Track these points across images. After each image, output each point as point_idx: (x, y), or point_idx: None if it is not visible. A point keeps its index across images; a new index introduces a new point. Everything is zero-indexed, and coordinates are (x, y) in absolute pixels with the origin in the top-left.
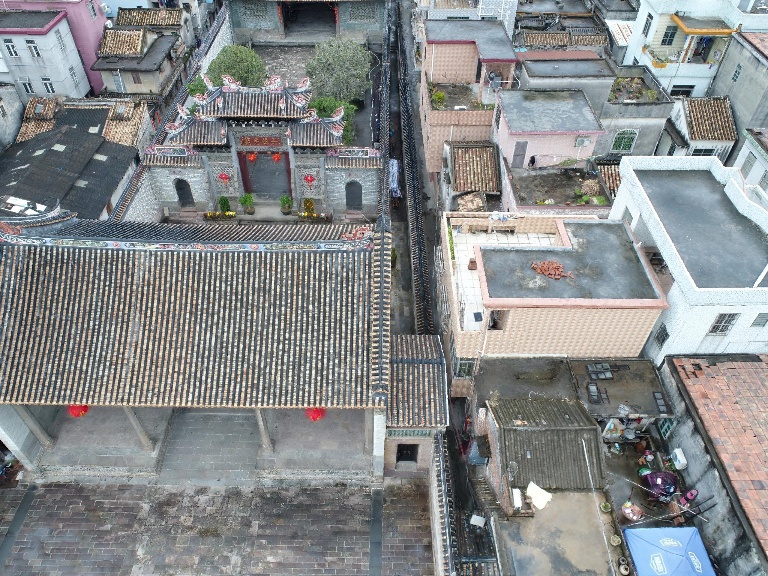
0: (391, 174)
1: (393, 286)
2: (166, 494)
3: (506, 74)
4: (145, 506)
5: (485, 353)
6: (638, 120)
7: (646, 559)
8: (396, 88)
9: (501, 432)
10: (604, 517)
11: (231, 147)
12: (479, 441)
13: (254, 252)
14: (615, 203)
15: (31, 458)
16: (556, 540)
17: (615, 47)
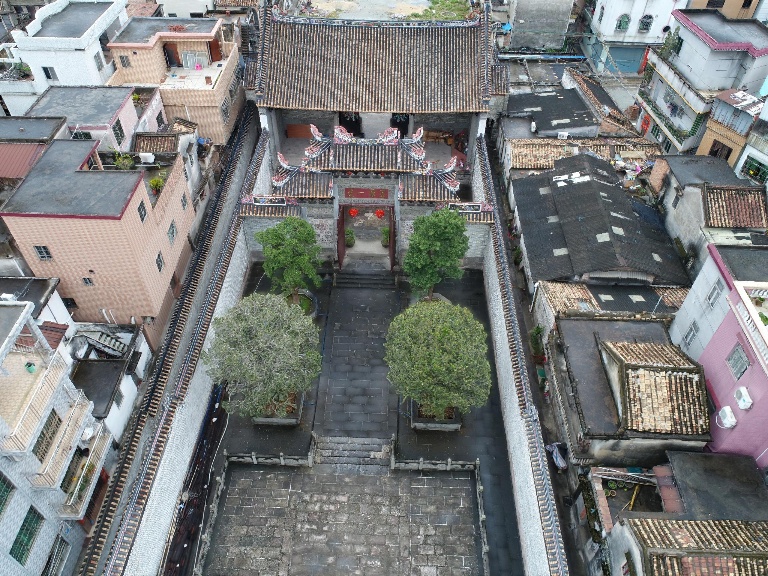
0: None
1: None
2: None
3: None
4: None
5: None
6: None
7: None
8: None
9: None
10: None
11: None
12: (241, 50)
13: None
14: None
15: None
16: (227, 22)
17: None
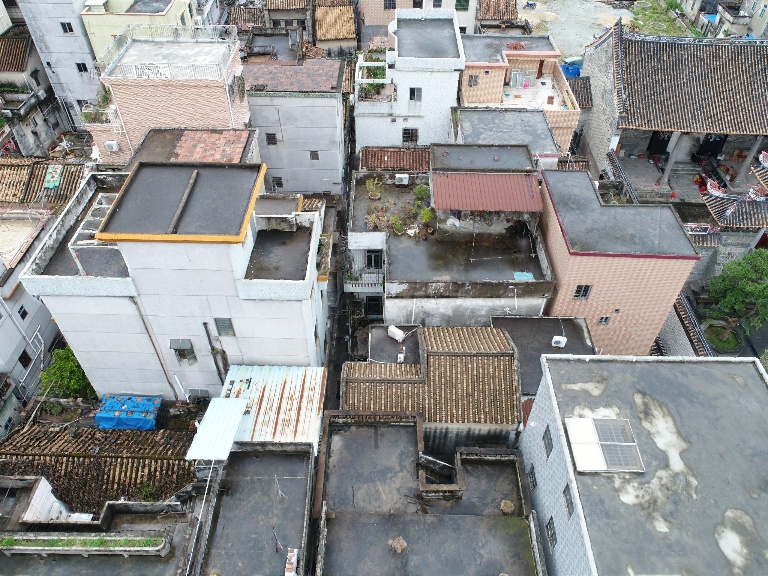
0: None
1: None
2: None
3: None
4: None
5: None
6: None
7: None
8: None
9: None
10: None
11: None
12: None
13: None
14: None
15: None
16: None
17: None
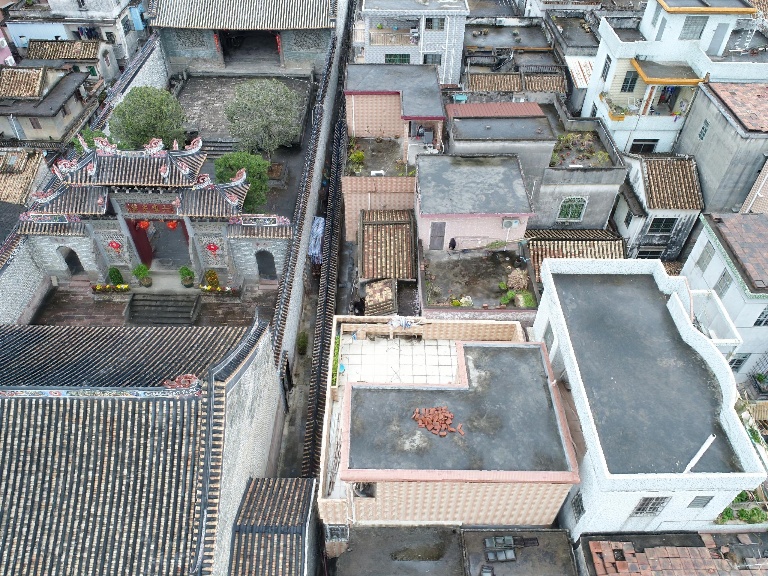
0: (314, 236)
1: (300, 379)
2: None
3: (436, 130)
4: None
5: (358, 520)
6: (586, 186)
7: None
8: None
9: None
10: None
11: (117, 214)
12: None
13: (57, 399)
14: (539, 309)
15: None
16: None
17: (575, 88)
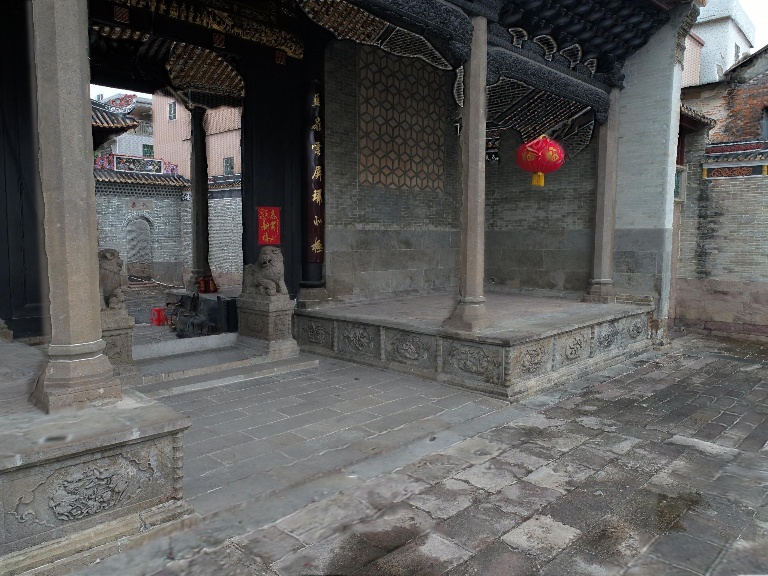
0: None
1: None
2: (315, 536)
3: None
4: None
5: None
6: None
7: None
8: None
9: None
10: None
11: None
12: None
13: None
14: None
15: None
16: None
17: None
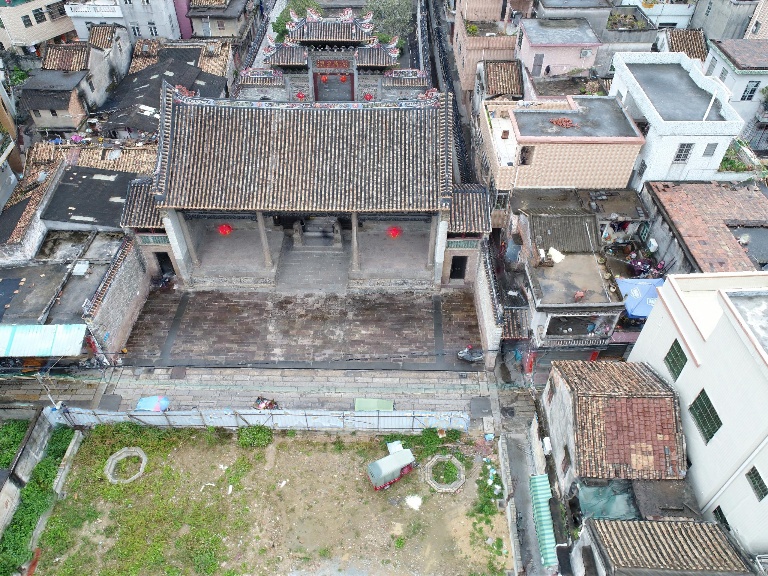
0: None
1: None
2: (283, 297)
3: (525, 11)
4: (270, 303)
5: (516, 185)
6: (630, 45)
7: (628, 292)
8: (429, 39)
9: (531, 217)
10: (600, 266)
11: (309, 69)
12: (514, 236)
13: (355, 110)
14: (610, 91)
15: (187, 269)
16: (568, 277)
17: None
